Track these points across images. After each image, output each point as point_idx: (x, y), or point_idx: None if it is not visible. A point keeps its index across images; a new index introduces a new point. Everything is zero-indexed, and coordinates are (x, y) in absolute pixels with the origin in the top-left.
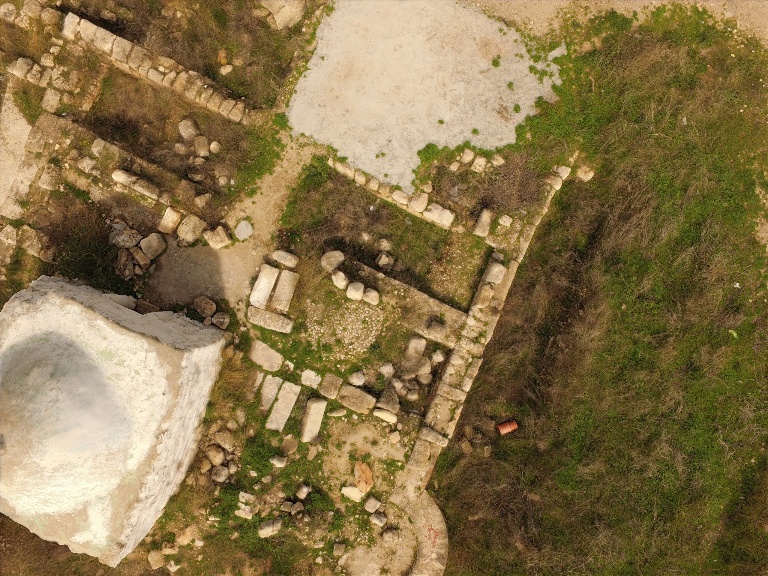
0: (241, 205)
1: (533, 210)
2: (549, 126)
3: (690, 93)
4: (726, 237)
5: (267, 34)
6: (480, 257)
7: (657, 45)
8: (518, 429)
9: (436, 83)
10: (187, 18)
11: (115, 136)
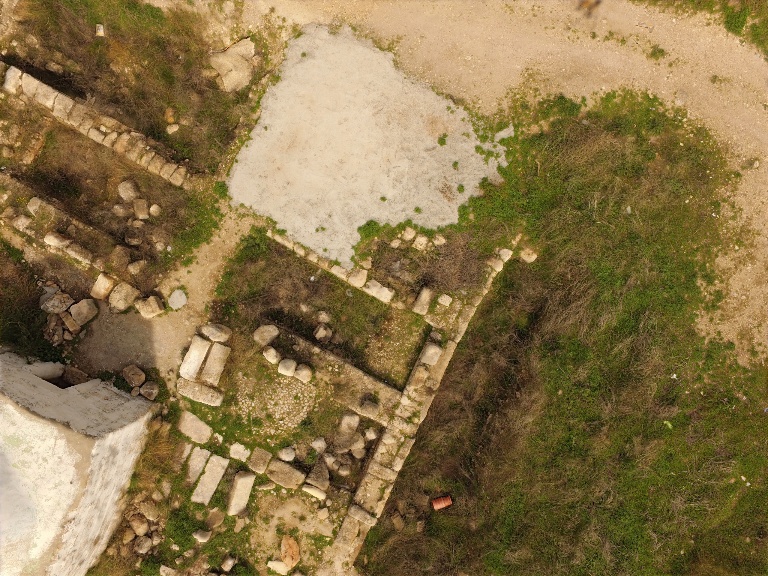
0: (176, 274)
1: (472, 292)
2: (492, 209)
3: (636, 181)
4: (665, 328)
5: (215, 95)
6: (418, 335)
7: (602, 135)
8: (452, 505)
9: (380, 159)
10: (135, 74)
11: (57, 189)
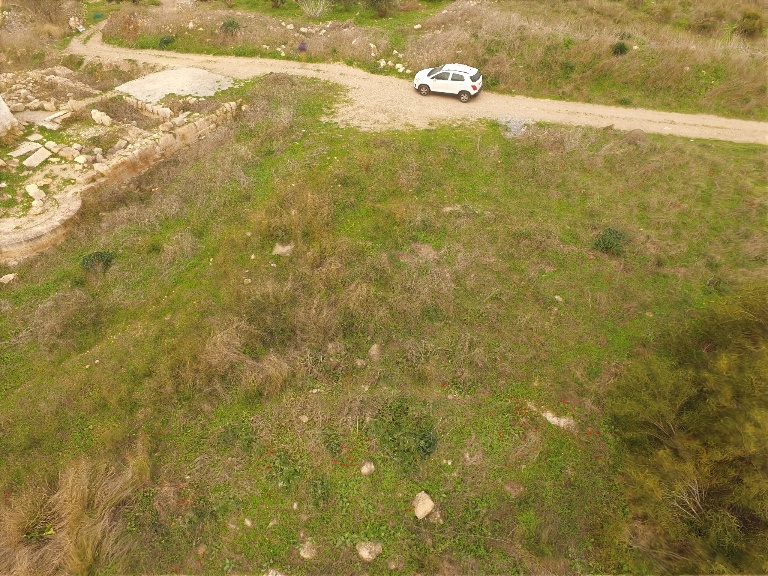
0: None
1: (210, 110)
2: None
3: None
4: None
5: None
6: None
7: None
8: None
9: (188, 84)
10: None
11: None
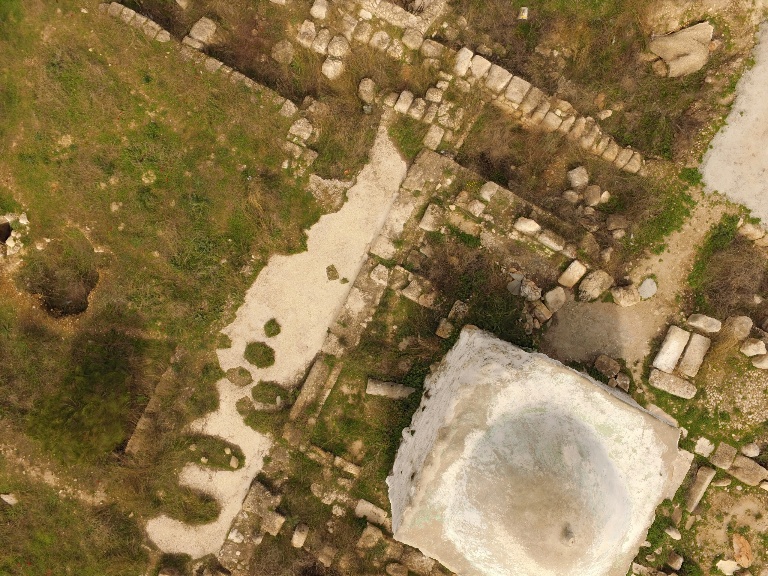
0: (648, 262)
1: None
2: None
3: None
4: None
5: None
6: None
7: None
8: None
9: None
10: (565, 58)
11: None
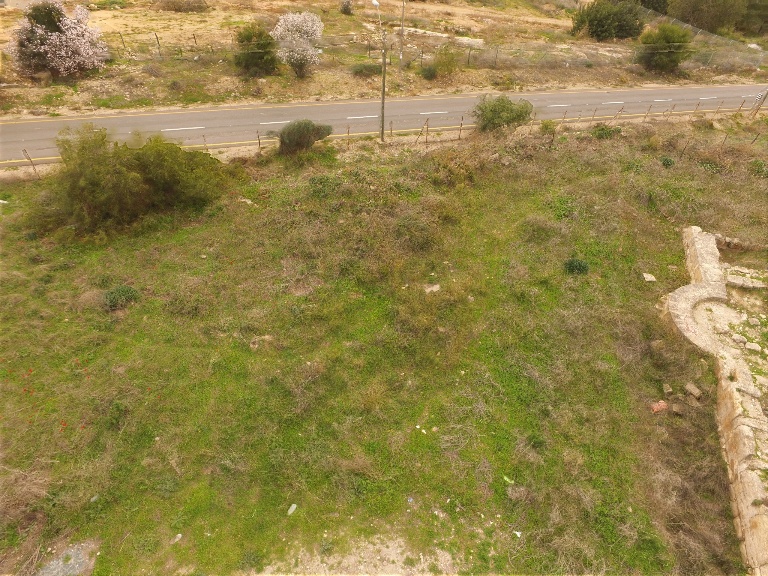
0: None
1: None
2: None
3: None
4: None
5: None
6: None
7: None
8: None
9: None
10: None
11: None
